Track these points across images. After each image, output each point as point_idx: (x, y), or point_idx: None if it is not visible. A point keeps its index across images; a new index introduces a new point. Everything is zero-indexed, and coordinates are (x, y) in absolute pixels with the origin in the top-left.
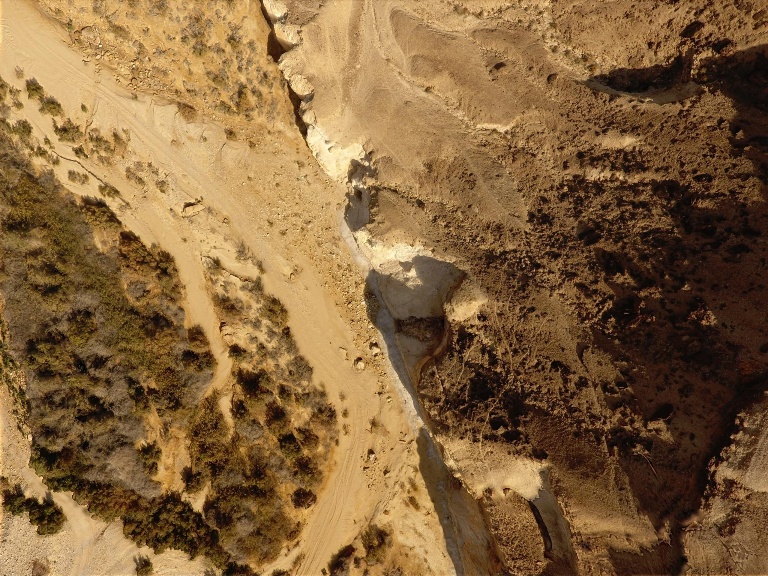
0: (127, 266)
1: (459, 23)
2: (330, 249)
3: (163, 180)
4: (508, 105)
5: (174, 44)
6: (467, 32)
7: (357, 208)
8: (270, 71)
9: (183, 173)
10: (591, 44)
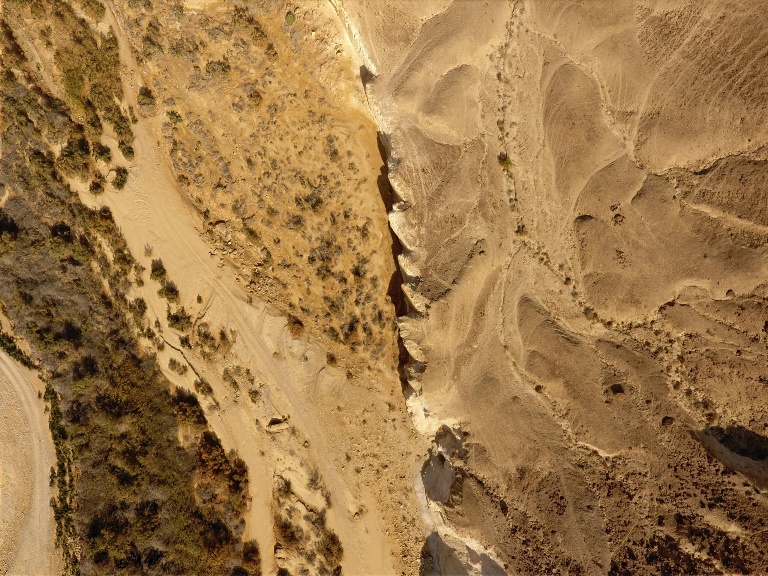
0: (203, 472)
1: (585, 327)
2: (399, 498)
3: (257, 390)
4: (616, 435)
5: (300, 261)
6: (591, 339)
7: (437, 472)
8: (385, 311)
9: (277, 387)
10: (715, 393)
